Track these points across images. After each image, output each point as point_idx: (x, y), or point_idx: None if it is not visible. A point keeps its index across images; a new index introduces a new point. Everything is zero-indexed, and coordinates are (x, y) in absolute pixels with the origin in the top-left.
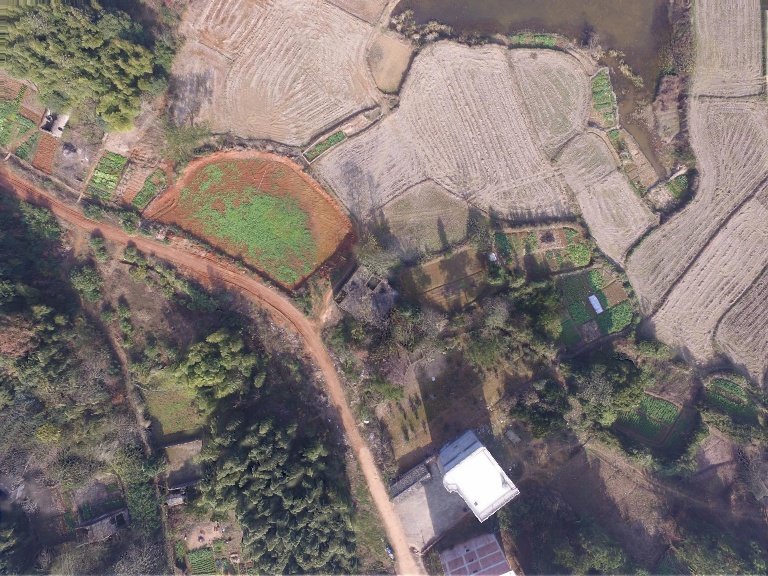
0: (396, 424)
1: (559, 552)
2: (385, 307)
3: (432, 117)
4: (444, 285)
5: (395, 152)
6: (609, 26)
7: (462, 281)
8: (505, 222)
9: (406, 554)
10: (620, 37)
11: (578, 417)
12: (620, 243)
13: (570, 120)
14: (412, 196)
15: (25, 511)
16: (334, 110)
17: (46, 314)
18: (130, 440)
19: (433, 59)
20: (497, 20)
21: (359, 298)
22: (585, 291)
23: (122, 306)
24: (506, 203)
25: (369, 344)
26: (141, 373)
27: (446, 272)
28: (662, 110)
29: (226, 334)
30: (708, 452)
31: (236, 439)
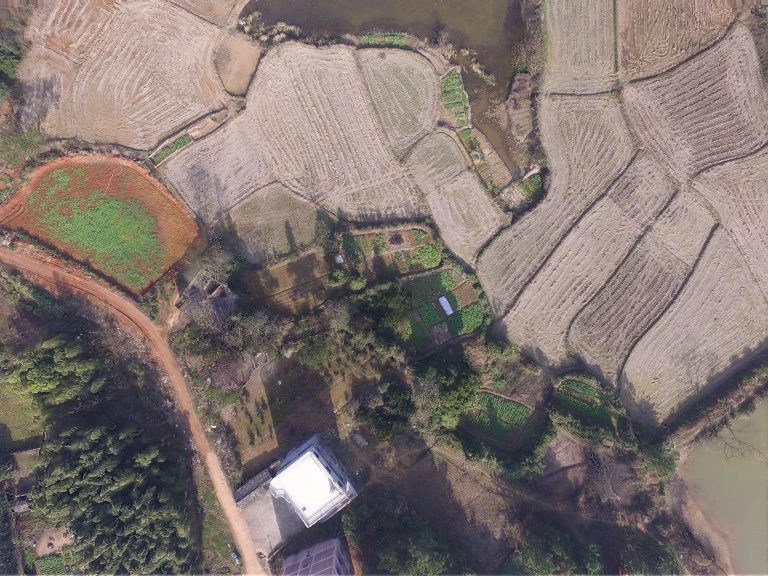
0: (242, 429)
1: (383, 557)
2: (226, 311)
3: (279, 119)
4: (292, 288)
5: (242, 155)
6: (461, 24)
7: (310, 284)
8: (351, 224)
9: (253, 559)
10: (472, 35)
11: (426, 420)
12: (471, 244)
13: (420, 120)
14: (259, 199)
15: None
16: (181, 113)
17: None
18: None
19: (279, 60)
20: (347, 20)
21: (199, 302)
22: (435, 293)
23: None
24: (355, 205)
25: (206, 348)
26: None
27: (294, 275)
28: (515, 109)
29: (62, 340)
30: (559, 454)
31: (70, 445)
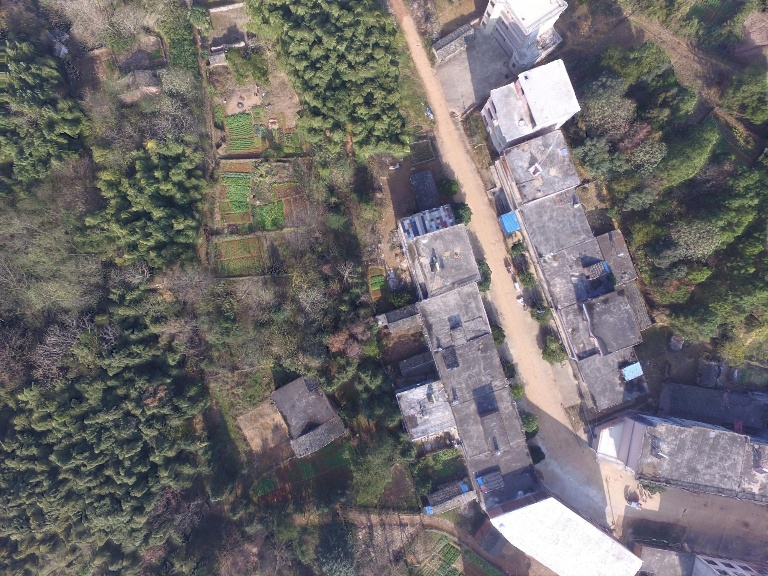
0: None
1: (607, 53)
2: None
3: None
4: None
5: None
6: None
7: None
8: None
9: (446, 118)
10: None
11: None
12: None
13: None
14: None
15: (67, 72)
16: None
17: None
18: None
19: None
20: None
21: None
22: None
23: None
24: None
25: None
26: None
27: None
28: None
29: None
30: (754, 33)
31: None
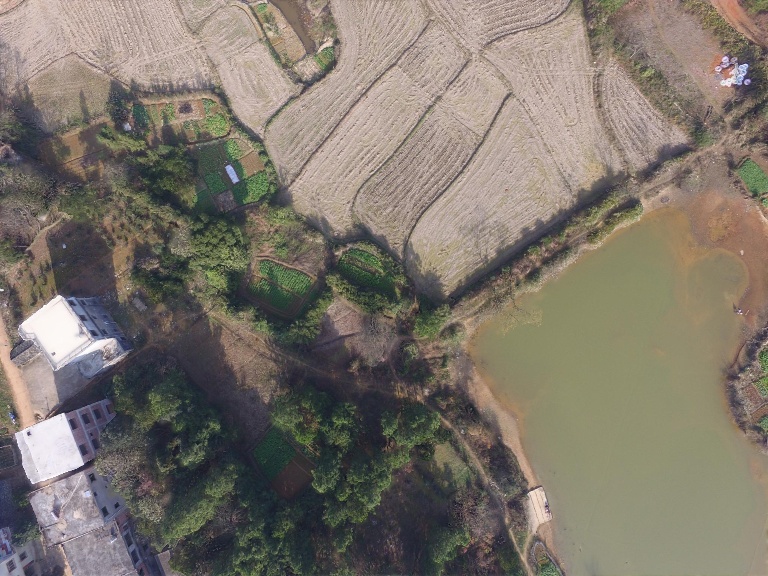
0: (26, 291)
1: (119, 398)
2: None
3: None
4: (84, 156)
5: (42, 28)
6: None
7: (101, 152)
8: (140, 92)
9: (31, 421)
10: None
11: (204, 285)
12: (261, 114)
13: None
14: (56, 70)
15: None
16: None
17: None
18: None
19: None
20: None
21: None
22: (221, 161)
23: None
24: (148, 76)
25: None
26: None
27: (85, 143)
28: None
29: None
30: (338, 323)
31: None
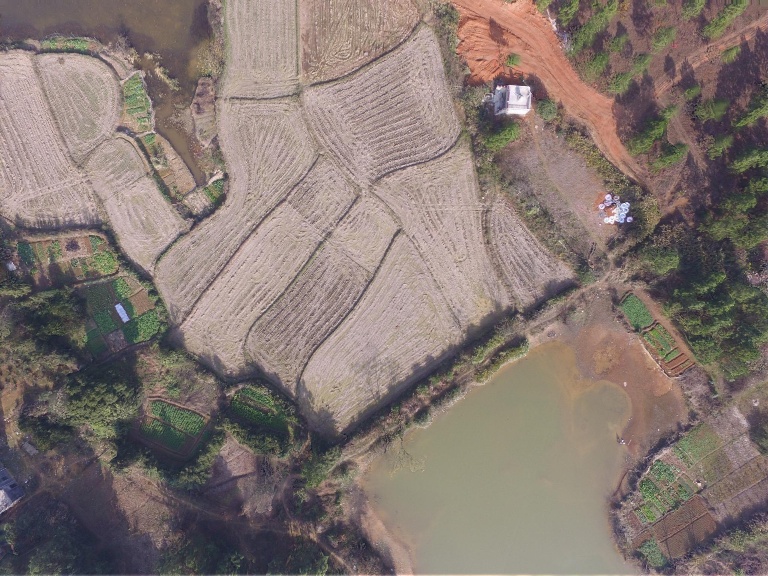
0: None
1: None
2: None
3: None
4: None
5: None
6: (146, 28)
7: None
8: (24, 231)
9: None
10: (158, 39)
11: None
12: (150, 250)
13: (99, 125)
14: None
15: None
16: None
17: None
18: None
19: None
20: (30, 25)
21: None
22: (110, 300)
23: None
24: (33, 211)
25: None
26: None
27: None
28: (198, 113)
29: None
30: (231, 463)
31: None
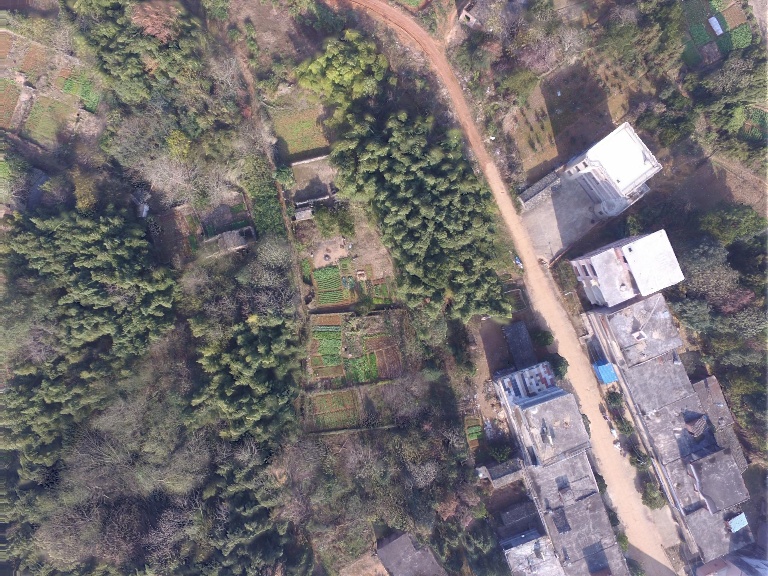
0: (523, 138)
1: (706, 218)
2: (514, 15)
3: None
4: (566, 7)
5: None
6: None
7: (584, 3)
8: None
9: (534, 266)
10: None
11: (703, 131)
12: None
13: None
14: None
15: (150, 231)
16: None
17: (182, 13)
18: (258, 155)
19: None
20: None
21: (488, 6)
22: (705, 13)
23: (249, 24)
24: None
25: None
26: (269, 88)
27: None
28: None
29: None
30: None
31: (373, 132)
